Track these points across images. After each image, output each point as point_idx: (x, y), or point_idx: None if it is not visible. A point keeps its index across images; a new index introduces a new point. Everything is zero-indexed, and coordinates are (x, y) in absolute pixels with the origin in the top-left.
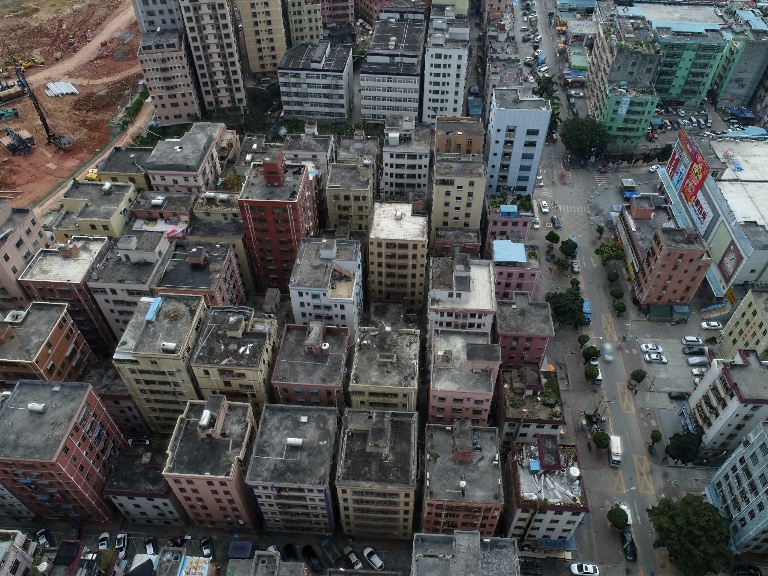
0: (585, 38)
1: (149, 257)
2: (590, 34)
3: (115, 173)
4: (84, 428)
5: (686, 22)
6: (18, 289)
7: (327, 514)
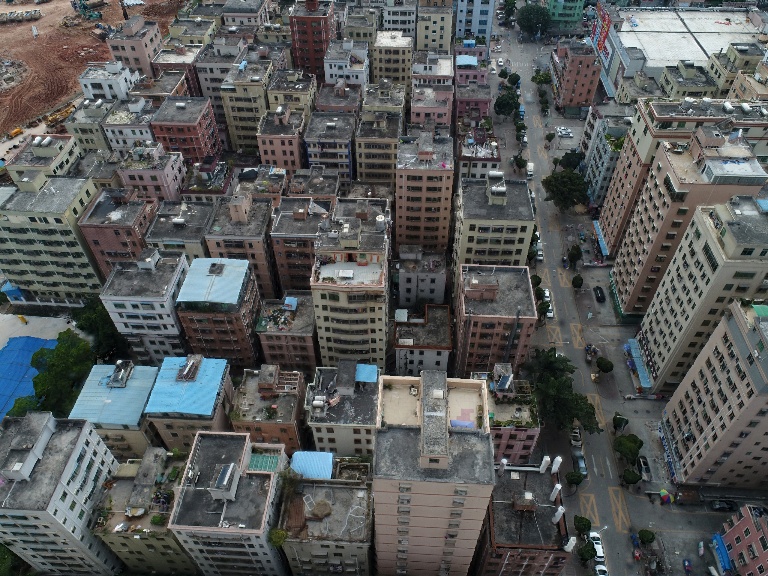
0: None
1: (233, 51)
2: None
3: (201, 16)
4: (207, 121)
5: None
6: (150, 70)
7: (349, 173)
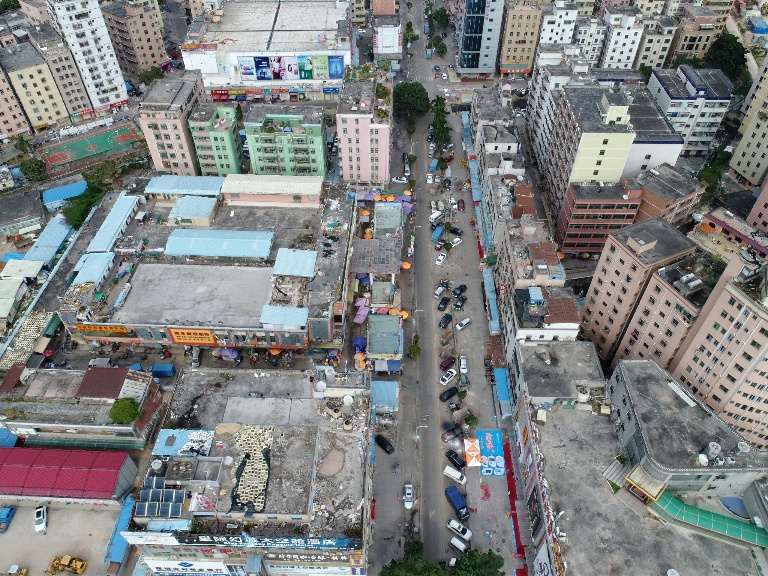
0: None
1: None
2: None
3: None
4: None
5: (213, 246)
6: None
7: None
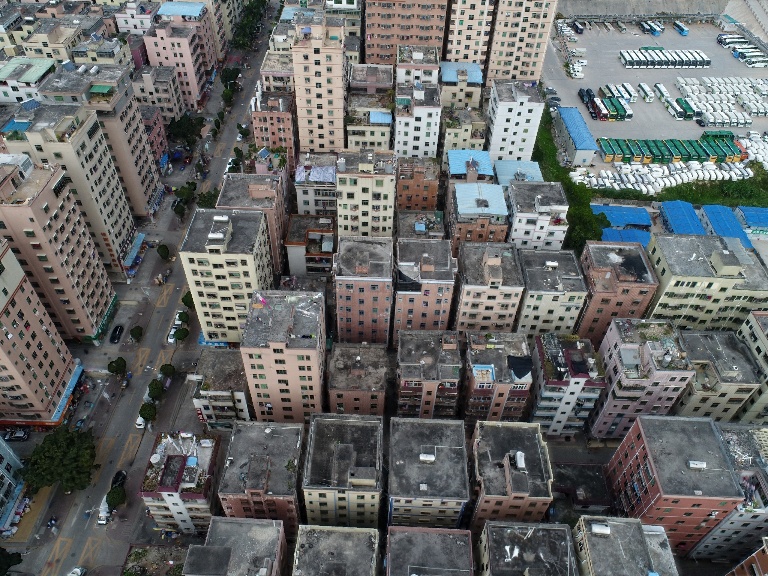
0: None
1: None
2: None
3: None
4: None
5: None
6: None
7: None
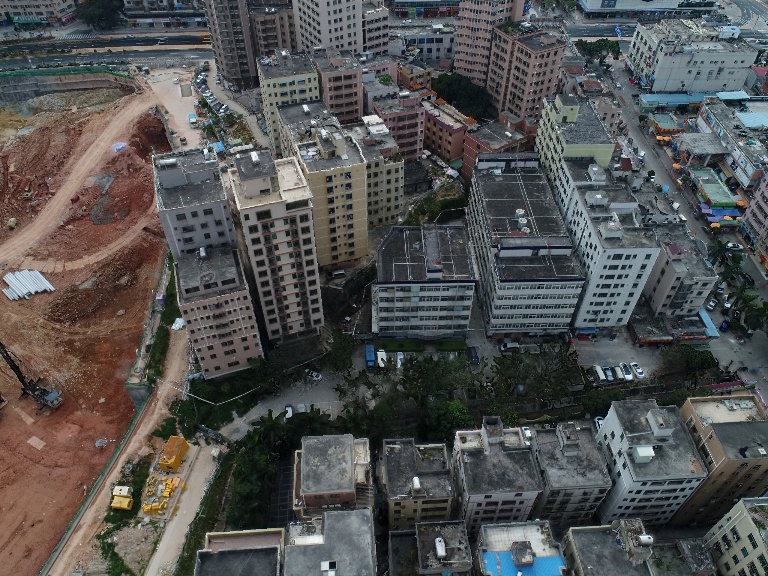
0: (708, 157)
1: None
2: (715, 153)
3: None
4: None
5: None
6: None
7: None
